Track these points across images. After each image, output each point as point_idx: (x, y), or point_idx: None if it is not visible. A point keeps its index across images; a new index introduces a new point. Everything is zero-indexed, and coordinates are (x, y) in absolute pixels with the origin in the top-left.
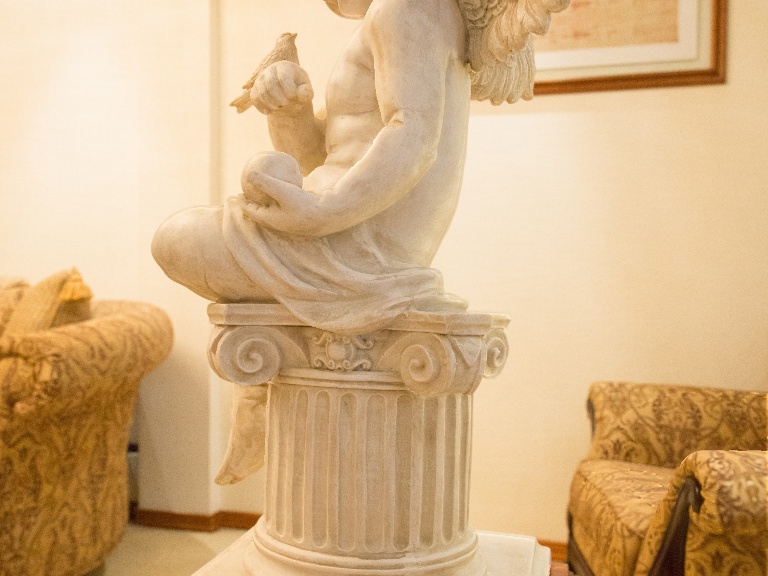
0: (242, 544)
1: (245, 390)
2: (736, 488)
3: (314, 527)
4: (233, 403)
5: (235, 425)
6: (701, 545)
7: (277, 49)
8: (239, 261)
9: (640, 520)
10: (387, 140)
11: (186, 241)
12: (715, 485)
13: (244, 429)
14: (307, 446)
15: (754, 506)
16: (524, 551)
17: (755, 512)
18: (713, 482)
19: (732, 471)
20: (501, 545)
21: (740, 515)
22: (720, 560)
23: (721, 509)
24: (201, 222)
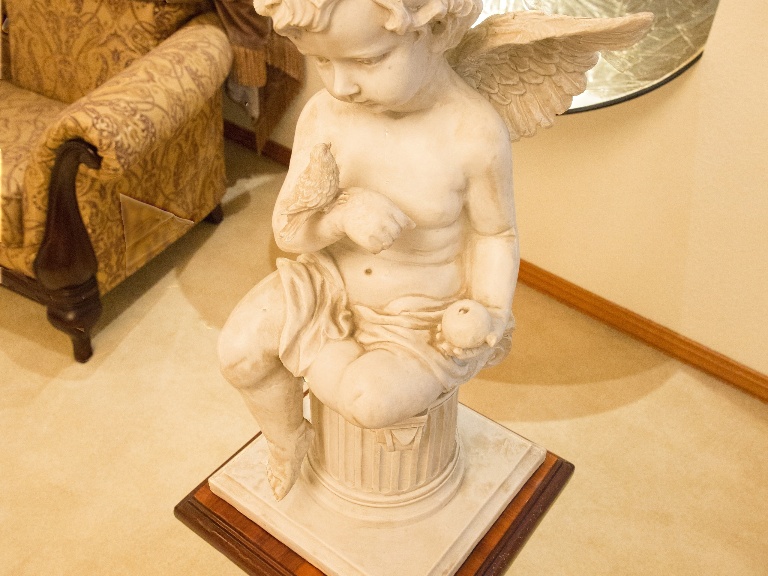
0: (299, 514)
1: (297, 433)
2: (125, 138)
3: (431, 471)
4: (288, 447)
5: (294, 458)
6: (90, 187)
7: (329, 171)
8: (448, 387)
9: (7, 184)
10: (516, 255)
11: (416, 403)
12: (112, 144)
13: (302, 455)
14: (431, 439)
15: (138, 146)
16: None
17: (140, 150)
18: (109, 142)
19: (115, 125)
20: None
21: (133, 158)
22: (104, 190)
23: (122, 161)
24: (421, 383)
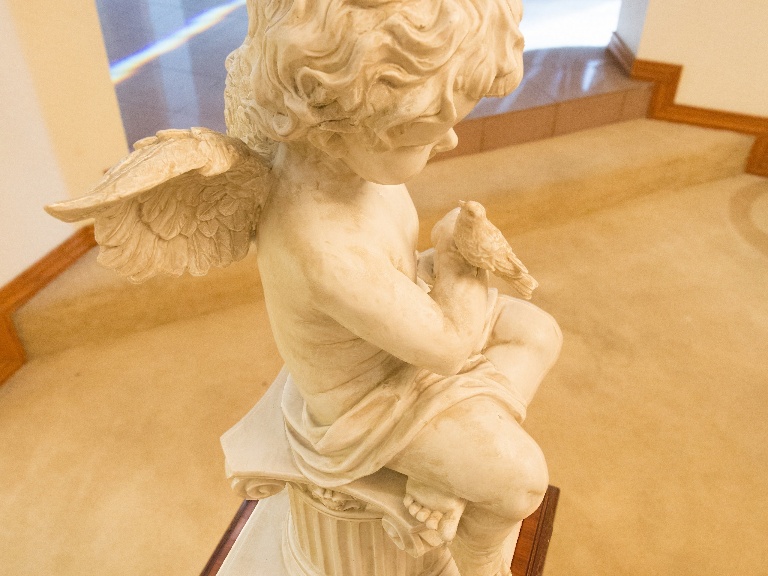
0: None
1: None
2: None
3: None
4: None
5: None
6: None
7: None
8: None
9: None
10: None
11: None
12: None
13: None
14: None
15: None
16: (235, 568)
17: None
18: None
19: None
20: None
21: None
22: None
23: None
24: None
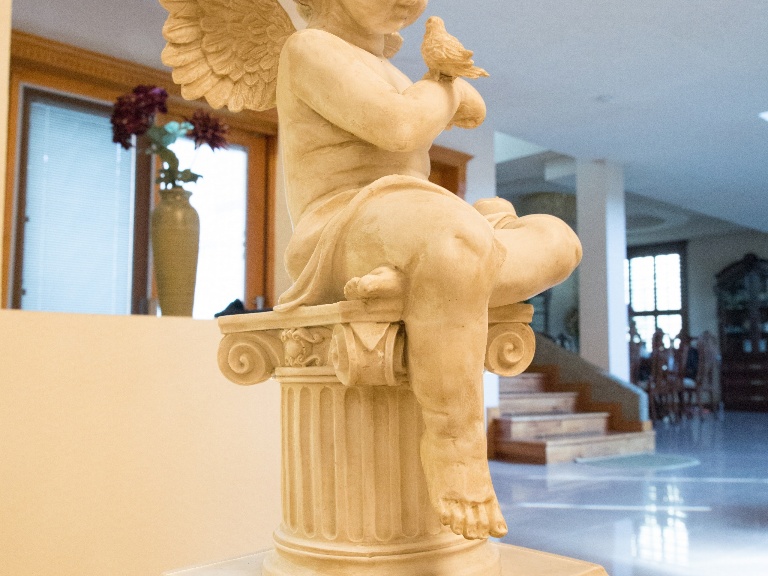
0: None
1: None
2: None
3: None
4: None
5: None
6: None
7: None
8: None
9: None
10: None
11: None
12: None
13: None
14: None
15: None
16: None
17: None
18: None
19: None
20: (220, 567)
21: None
22: None
23: None
24: None
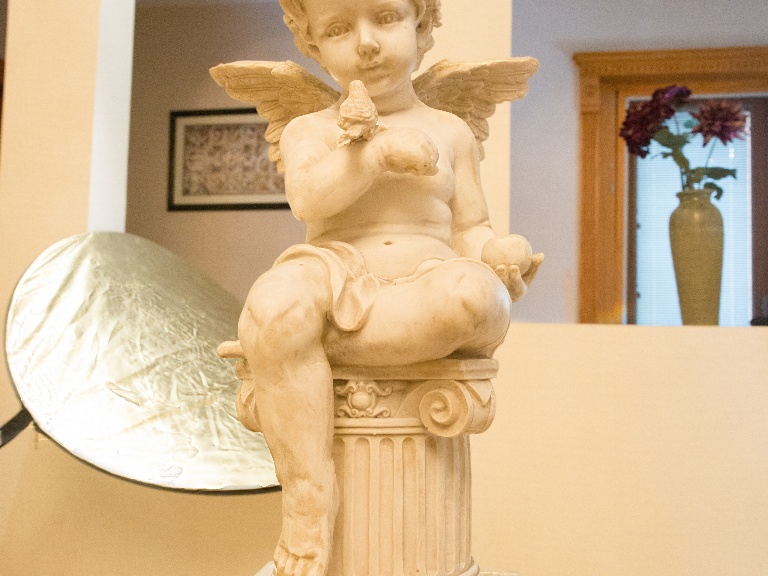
0: None
1: None
2: None
3: None
4: (326, 483)
5: (331, 508)
6: None
7: (370, 99)
8: None
9: None
10: None
11: None
12: None
13: (337, 509)
14: (467, 479)
15: None
16: None
17: None
18: None
19: None
20: None
21: None
22: None
23: None
24: None
